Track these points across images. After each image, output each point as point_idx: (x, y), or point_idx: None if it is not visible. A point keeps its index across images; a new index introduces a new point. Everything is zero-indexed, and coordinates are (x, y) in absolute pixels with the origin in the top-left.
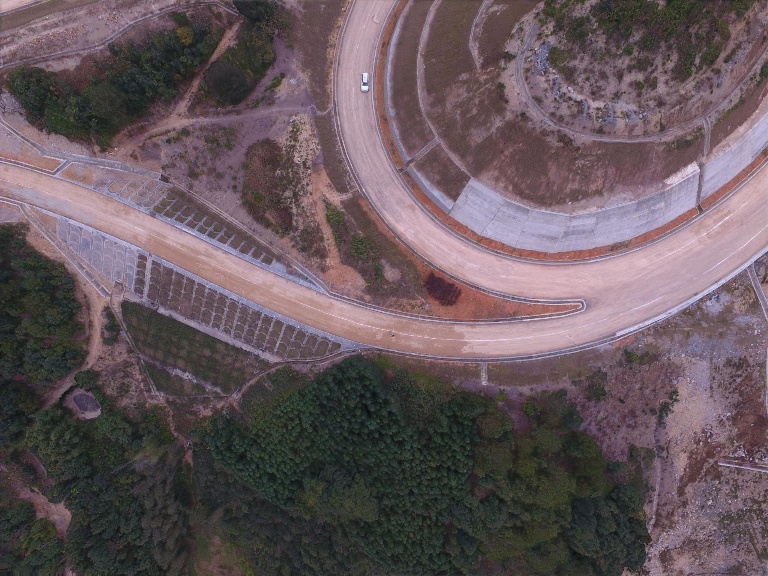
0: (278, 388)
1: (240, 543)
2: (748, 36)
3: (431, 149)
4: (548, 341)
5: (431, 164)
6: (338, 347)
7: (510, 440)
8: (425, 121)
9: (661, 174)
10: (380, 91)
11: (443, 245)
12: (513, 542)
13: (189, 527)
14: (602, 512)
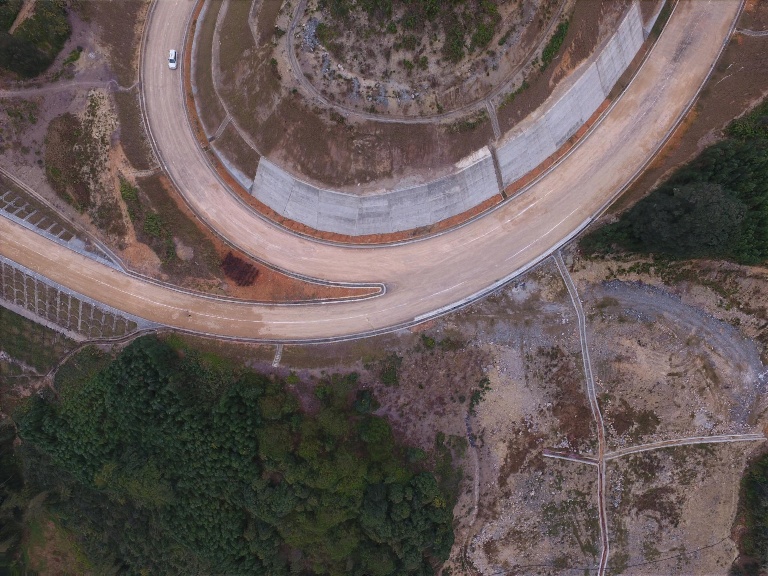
0: (85, 368)
1: (72, 528)
2: (522, 19)
3: (225, 127)
4: (346, 324)
5: (228, 142)
6: (135, 326)
7: (292, 422)
8: (218, 98)
9: (450, 157)
10: (188, 69)
11: (245, 225)
12: (310, 528)
13: (20, 511)
14: (392, 498)
